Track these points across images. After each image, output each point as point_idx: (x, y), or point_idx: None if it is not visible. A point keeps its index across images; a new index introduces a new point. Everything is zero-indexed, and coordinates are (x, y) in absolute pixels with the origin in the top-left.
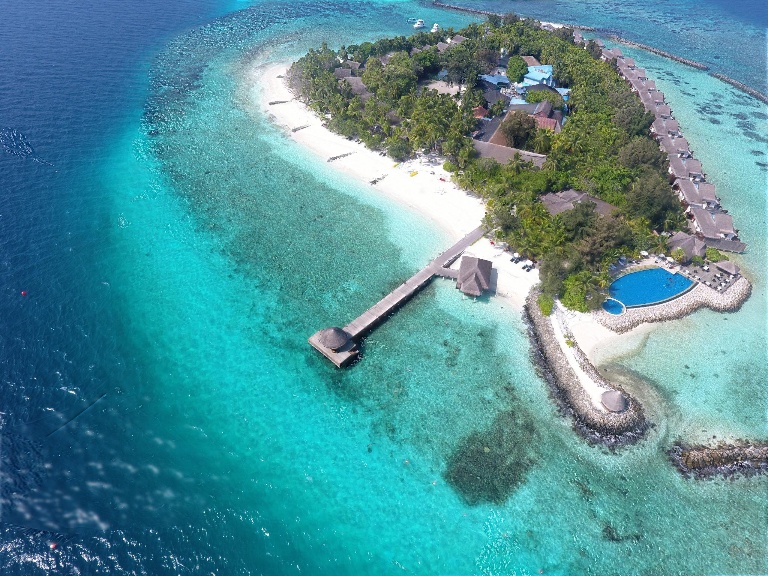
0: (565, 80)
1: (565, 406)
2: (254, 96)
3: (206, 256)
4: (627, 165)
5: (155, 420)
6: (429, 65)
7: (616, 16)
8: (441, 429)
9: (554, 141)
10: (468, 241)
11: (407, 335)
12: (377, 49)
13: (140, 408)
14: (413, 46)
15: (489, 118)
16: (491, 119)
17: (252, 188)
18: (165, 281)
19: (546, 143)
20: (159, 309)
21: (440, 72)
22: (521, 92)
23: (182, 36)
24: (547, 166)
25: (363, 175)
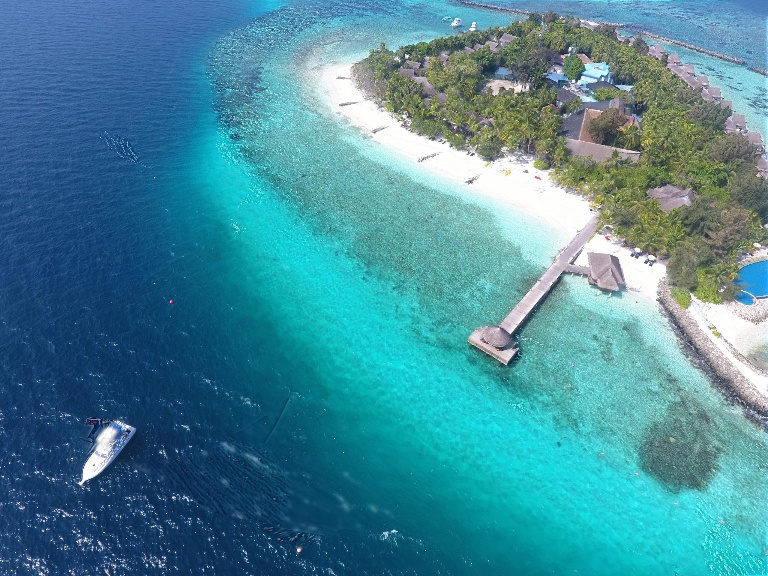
0: (625, 77)
1: (731, 395)
2: (321, 98)
3: (333, 259)
4: (721, 160)
5: (345, 423)
6: (486, 64)
7: (640, 12)
8: (622, 421)
9: (644, 138)
10: (584, 238)
11: (556, 331)
12: (433, 49)
13: (326, 411)
14: (464, 45)
15: (561, 116)
16: (564, 117)
17: (353, 190)
18: (301, 285)
19: (637, 140)
20: (305, 313)
21: (496, 71)
22: (586, 90)
23: (226, 38)
24: (644, 162)
25: (457, 175)
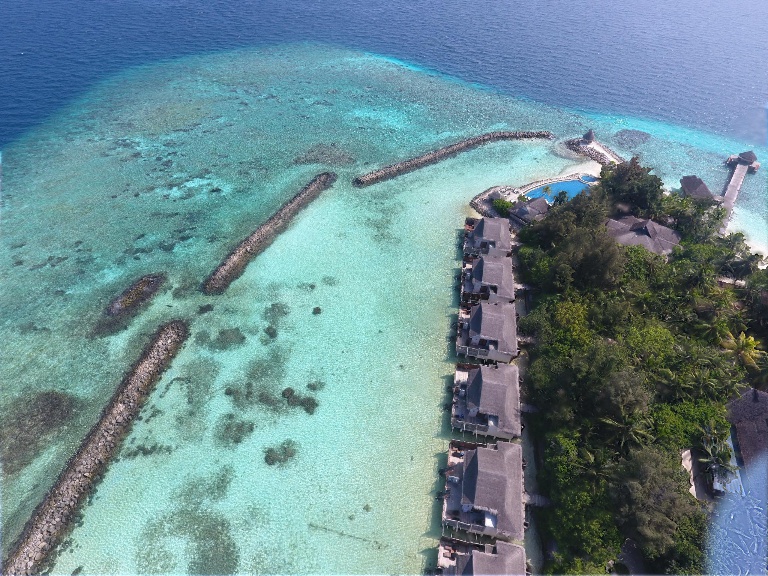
0: None
1: None
2: None
3: None
4: None
5: None
6: None
7: None
8: None
9: None
10: None
11: None
12: None
13: None
14: None
15: None
16: None
17: None
18: None
19: (734, 290)
20: None
21: None
22: None
23: None
24: None
25: None
